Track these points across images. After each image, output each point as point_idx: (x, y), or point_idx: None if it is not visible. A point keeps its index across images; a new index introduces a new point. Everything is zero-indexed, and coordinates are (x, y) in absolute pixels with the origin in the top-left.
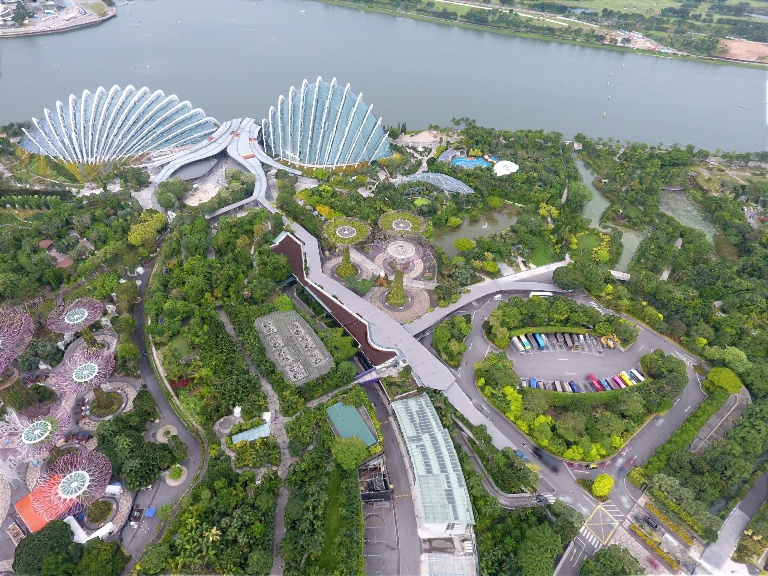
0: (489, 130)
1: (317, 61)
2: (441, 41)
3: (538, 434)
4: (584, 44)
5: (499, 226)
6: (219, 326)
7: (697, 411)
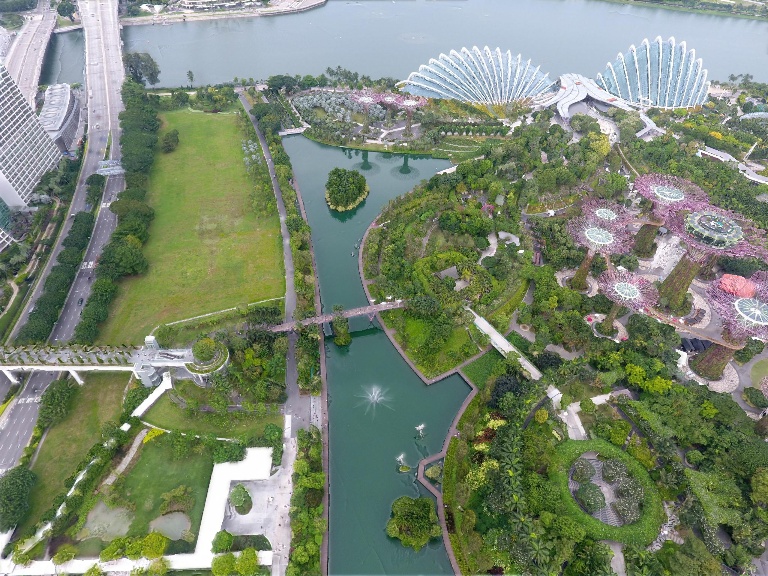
0: None
1: (547, 33)
2: (635, 17)
3: None
4: (763, 19)
5: None
6: None
7: None
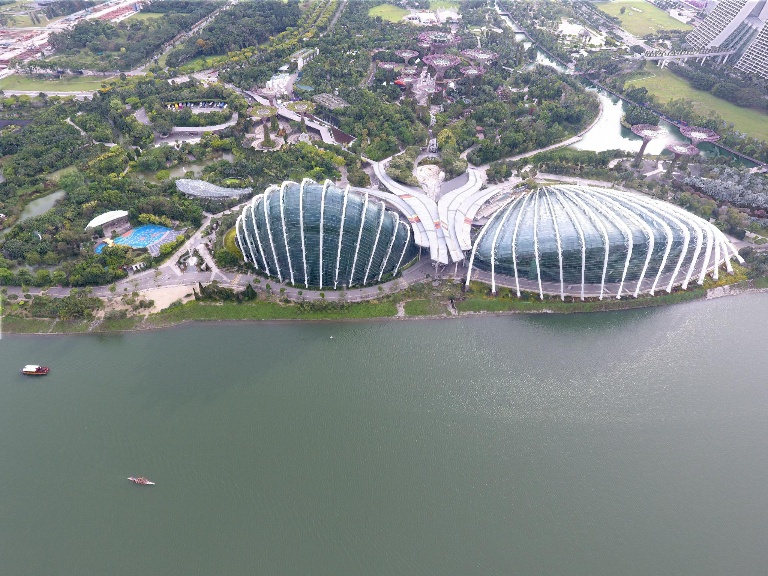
0: (49, 304)
1: None
2: None
3: None
4: None
5: (171, 174)
6: (368, 104)
7: None
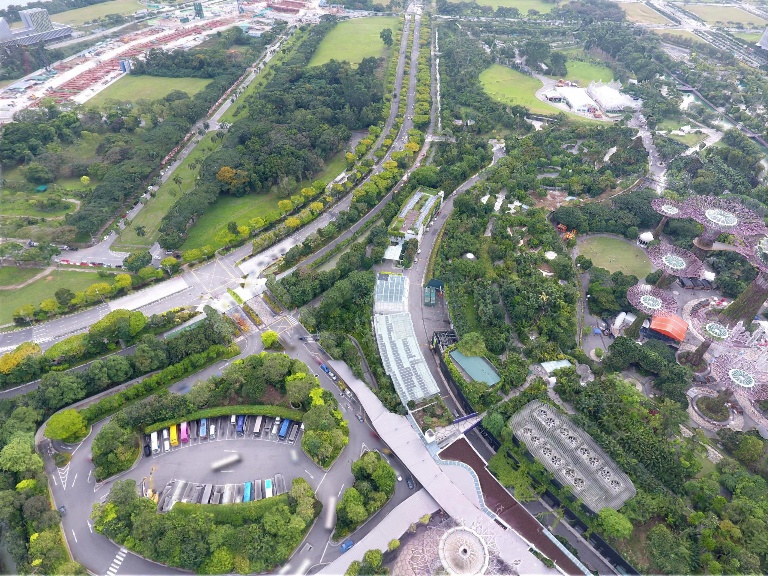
0: None
1: None
2: None
3: (306, 367)
4: None
5: None
6: (674, 477)
7: (132, 394)
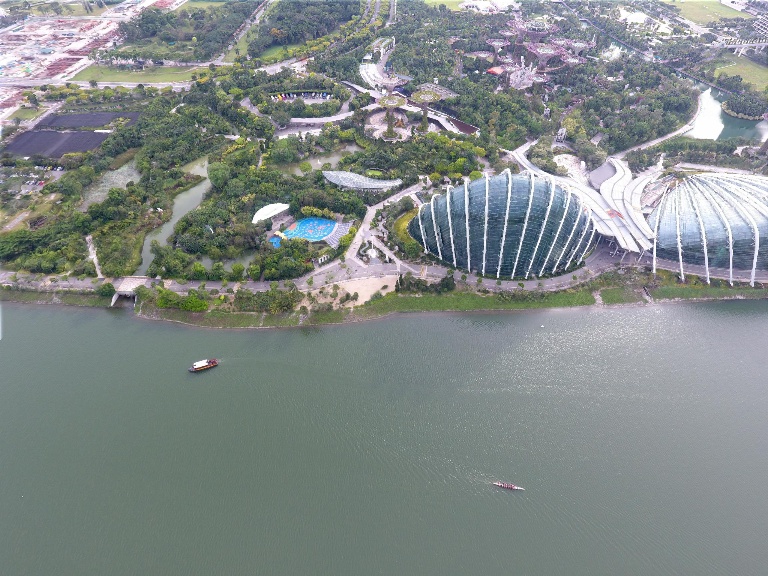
0: (254, 298)
1: None
2: None
3: None
4: None
5: None
6: None
7: None
